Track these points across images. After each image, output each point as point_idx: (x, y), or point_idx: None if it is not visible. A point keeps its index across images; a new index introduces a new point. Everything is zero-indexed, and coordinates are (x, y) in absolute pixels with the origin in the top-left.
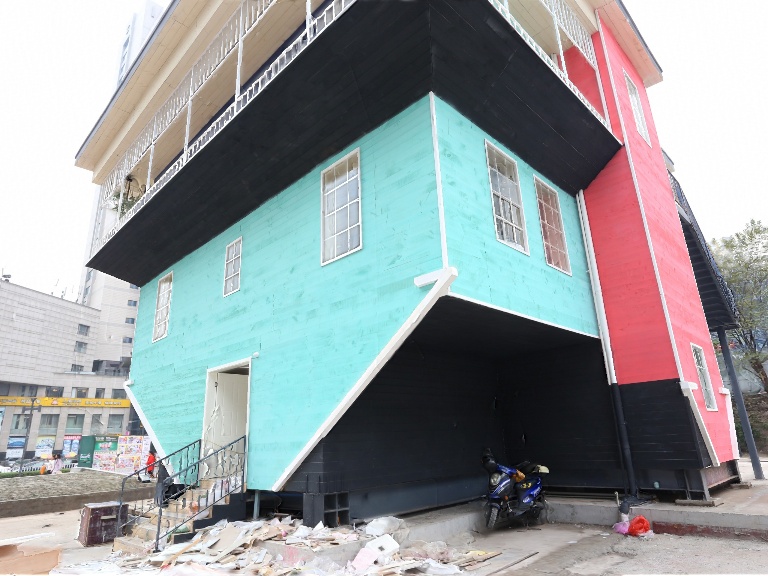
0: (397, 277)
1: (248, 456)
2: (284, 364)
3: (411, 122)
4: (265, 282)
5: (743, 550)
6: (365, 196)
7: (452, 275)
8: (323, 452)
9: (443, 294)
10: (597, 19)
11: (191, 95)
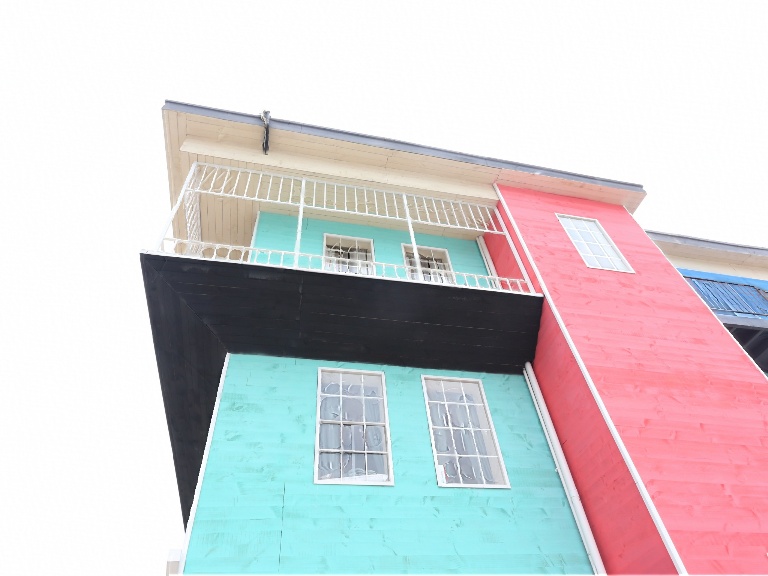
0: None
1: None
2: None
3: None
4: None
5: None
6: None
7: (168, 562)
8: None
9: None
10: (496, 191)
11: None
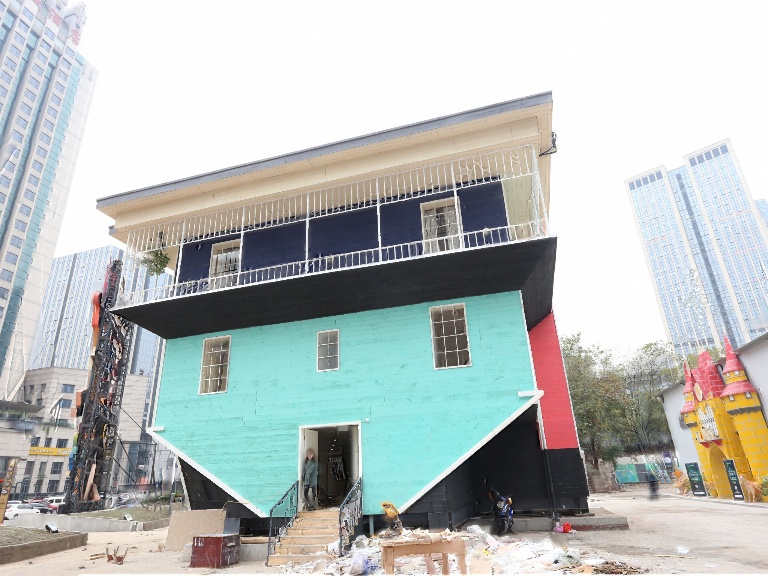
0: (502, 388)
1: (363, 492)
2: (400, 429)
3: (506, 302)
4: (372, 369)
5: (620, 533)
6: (472, 334)
7: None
8: (445, 487)
9: (535, 403)
10: None
11: (309, 216)
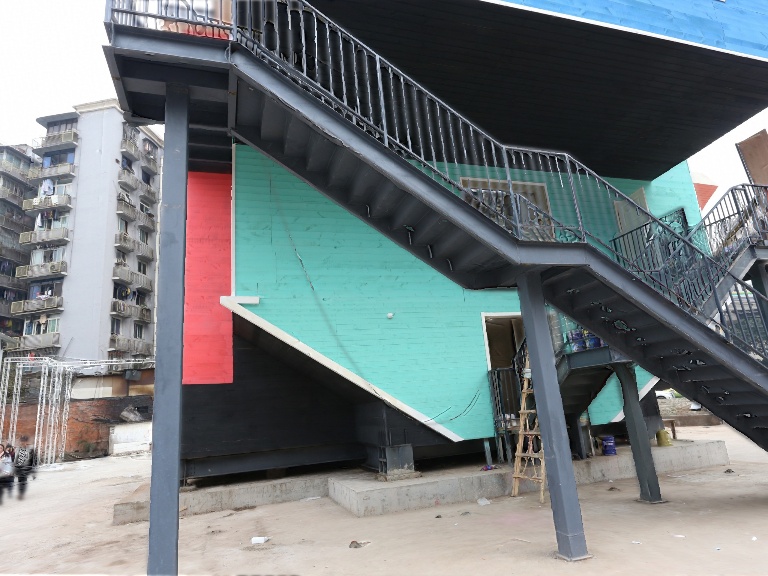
0: None
1: None
2: None
3: None
4: None
5: None
6: None
7: None
8: None
9: None
10: None
11: None
